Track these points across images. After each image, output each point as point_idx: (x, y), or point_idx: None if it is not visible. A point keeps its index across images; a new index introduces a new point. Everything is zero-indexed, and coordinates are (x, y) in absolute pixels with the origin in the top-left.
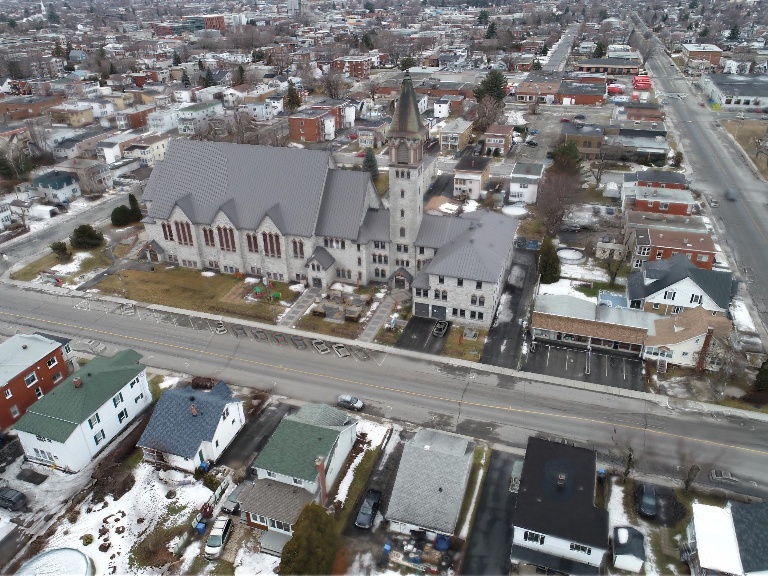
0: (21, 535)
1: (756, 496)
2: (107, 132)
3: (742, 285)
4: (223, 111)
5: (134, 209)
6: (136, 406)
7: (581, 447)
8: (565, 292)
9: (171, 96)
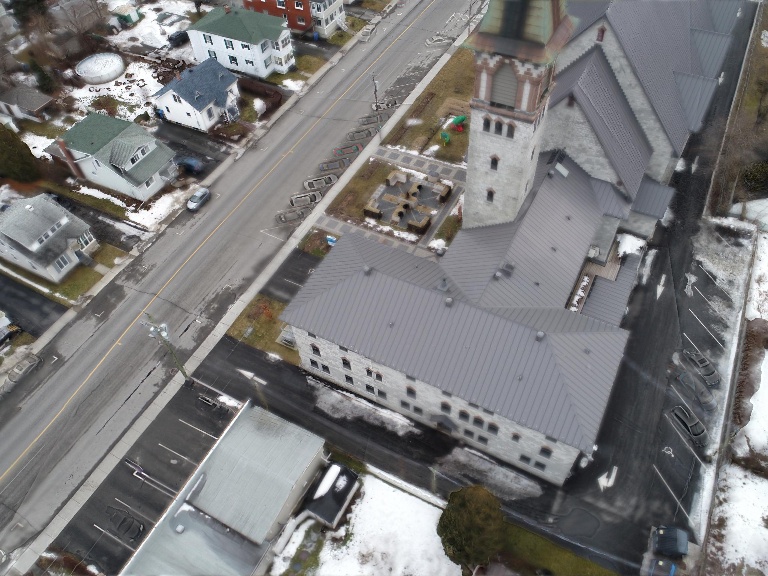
0: (150, 52)
1: None
2: None
3: None
4: None
5: None
6: (247, 66)
7: (9, 391)
8: (391, 548)
9: None
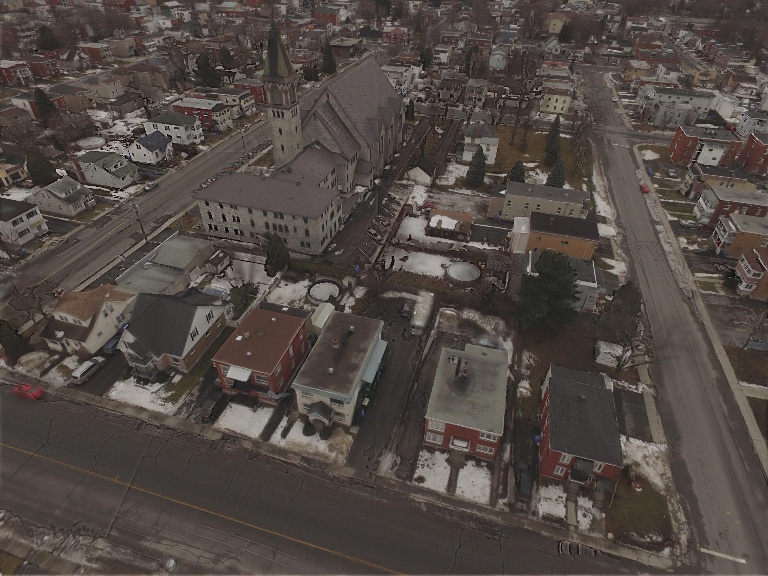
0: None
1: None
2: (621, 90)
3: (211, 433)
4: (688, 104)
5: (409, 110)
6: (177, 139)
7: (51, 249)
8: (244, 275)
9: (736, 85)
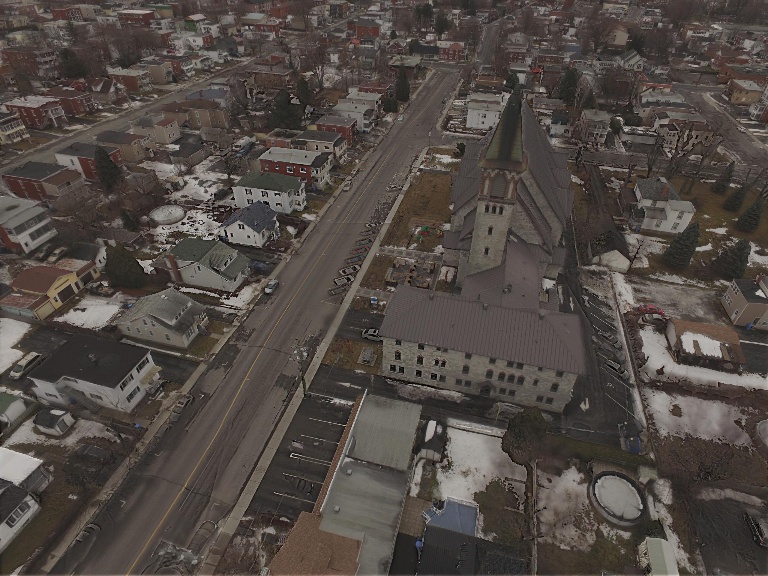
0: (200, 203)
1: (54, 567)
2: (737, 116)
3: None
4: None
5: None
6: (277, 207)
7: (176, 420)
8: (480, 464)
9: None
